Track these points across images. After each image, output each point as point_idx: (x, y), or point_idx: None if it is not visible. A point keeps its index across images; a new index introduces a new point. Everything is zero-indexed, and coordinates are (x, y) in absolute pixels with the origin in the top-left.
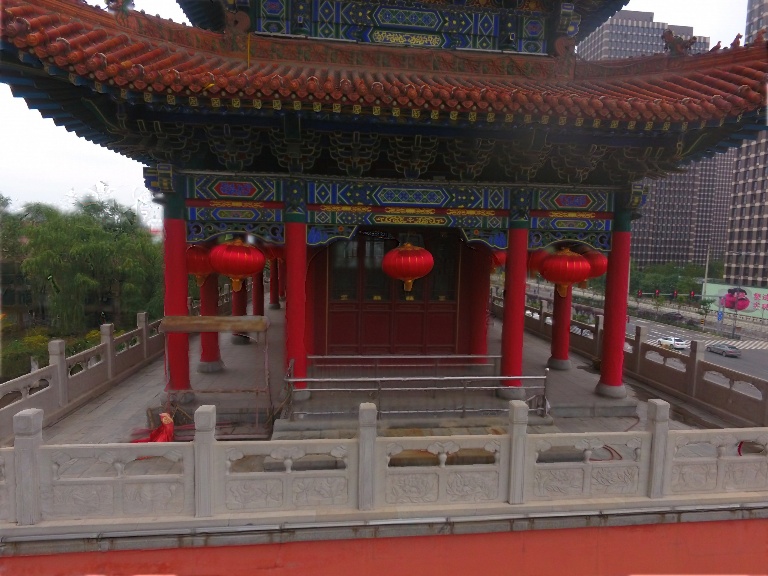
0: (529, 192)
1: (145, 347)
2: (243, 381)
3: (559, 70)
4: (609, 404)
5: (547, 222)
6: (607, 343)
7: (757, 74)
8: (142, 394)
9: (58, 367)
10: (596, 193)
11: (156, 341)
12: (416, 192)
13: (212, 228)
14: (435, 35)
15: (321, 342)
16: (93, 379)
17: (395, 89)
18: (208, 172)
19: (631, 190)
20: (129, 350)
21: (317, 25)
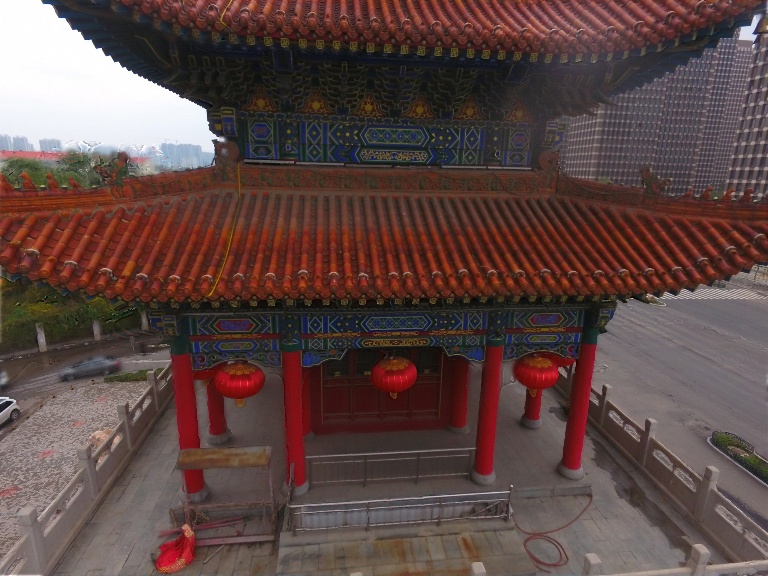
0: (506, 313)
1: (156, 401)
2: None
3: (542, 184)
4: (567, 486)
5: (521, 338)
6: (569, 434)
7: (718, 241)
8: (160, 468)
9: (87, 469)
10: (568, 311)
11: (165, 390)
12: (401, 319)
13: (215, 357)
14: (422, 151)
15: (317, 412)
16: (116, 458)
17: (379, 286)
18: (208, 313)
19: (599, 314)
20: (143, 413)
21: (305, 147)
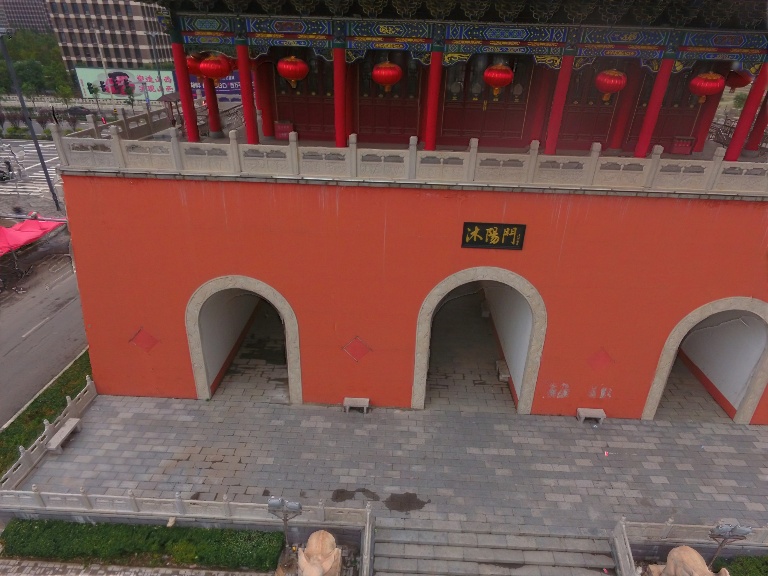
0: None
1: None
2: None
3: None
4: None
5: None
6: None
7: None
8: None
9: None
10: None
11: None
12: None
13: None
14: None
15: None
16: None
17: None
18: None
19: None
20: None
21: None
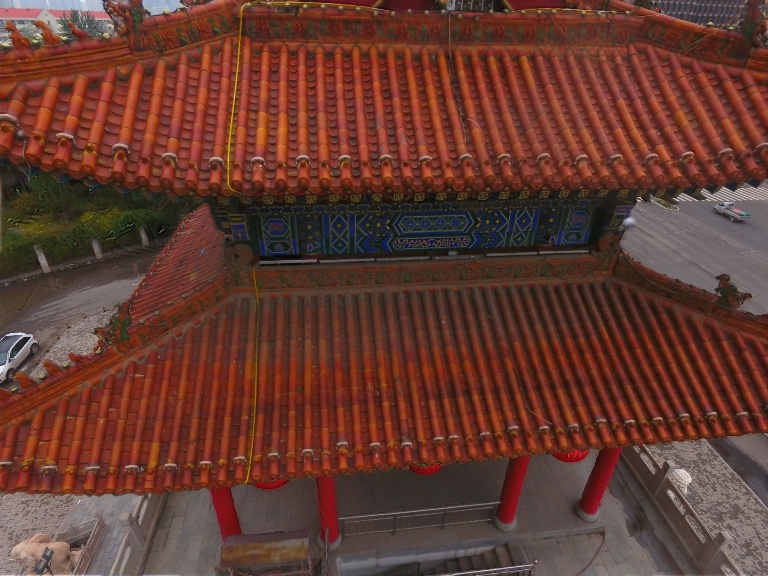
0: None
1: None
2: (281, 497)
3: (598, 268)
4: (583, 529)
5: None
6: (591, 488)
7: None
8: (198, 504)
9: (132, 532)
10: None
11: None
12: None
13: None
14: (464, 236)
15: None
16: (154, 499)
17: (424, 460)
18: None
19: None
20: None
21: (329, 240)
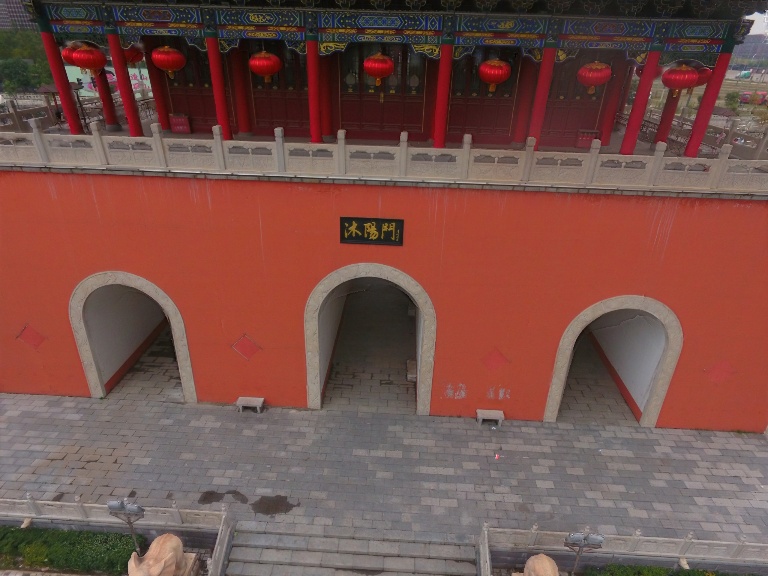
0: None
1: None
2: None
3: None
4: None
5: None
6: None
7: None
8: None
9: None
10: None
11: None
12: None
13: None
14: None
15: None
16: None
17: None
18: None
19: None
20: None
21: None
